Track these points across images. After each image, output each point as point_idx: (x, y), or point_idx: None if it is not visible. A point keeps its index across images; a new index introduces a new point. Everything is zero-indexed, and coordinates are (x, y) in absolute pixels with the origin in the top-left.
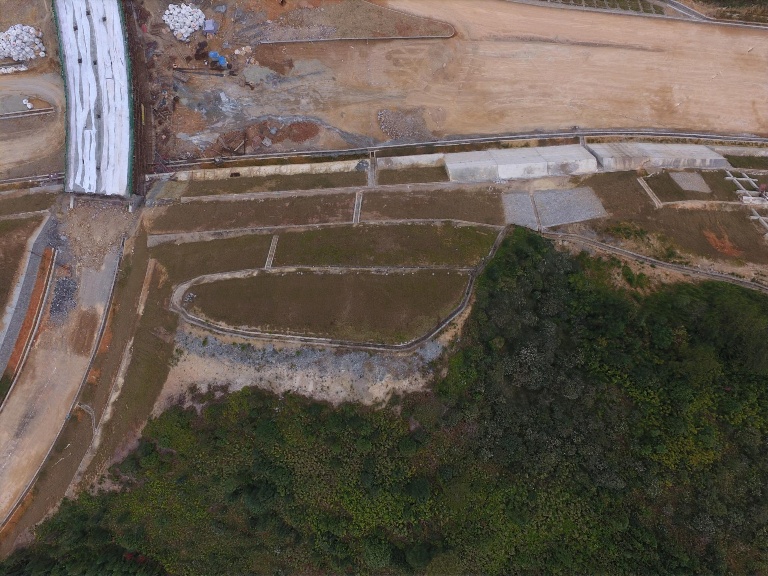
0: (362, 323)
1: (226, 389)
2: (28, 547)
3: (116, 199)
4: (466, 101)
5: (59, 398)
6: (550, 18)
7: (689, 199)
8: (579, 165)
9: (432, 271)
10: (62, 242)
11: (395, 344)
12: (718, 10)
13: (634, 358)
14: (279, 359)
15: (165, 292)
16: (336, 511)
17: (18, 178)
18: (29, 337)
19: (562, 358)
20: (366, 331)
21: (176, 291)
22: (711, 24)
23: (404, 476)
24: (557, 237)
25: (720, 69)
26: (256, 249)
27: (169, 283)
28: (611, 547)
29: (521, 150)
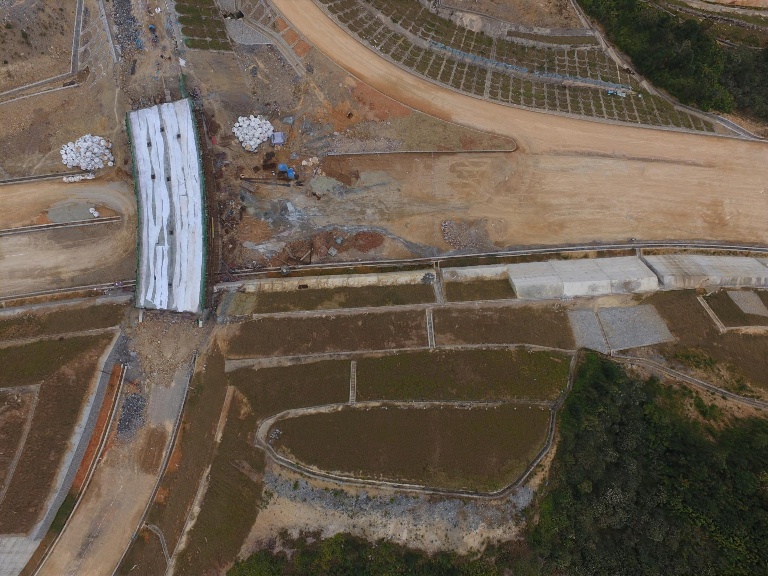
0: (454, 469)
1: (318, 536)
2: None
3: (186, 314)
4: (527, 213)
5: (125, 517)
6: (607, 134)
7: (752, 325)
8: (641, 283)
9: (514, 405)
10: (131, 358)
11: (488, 492)
12: (766, 129)
13: (718, 502)
14: (373, 506)
15: (249, 426)
16: None
17: (82, 286)
18: (95, 455)
19: (645, 497)
20: (459, 478)
21: (261, 426)
22: (759, 142)
23: None
24: (626, 360)
25: (767, 184)
26: (337, 379)
27: (253, 417)
28: None
29: (581, 262)
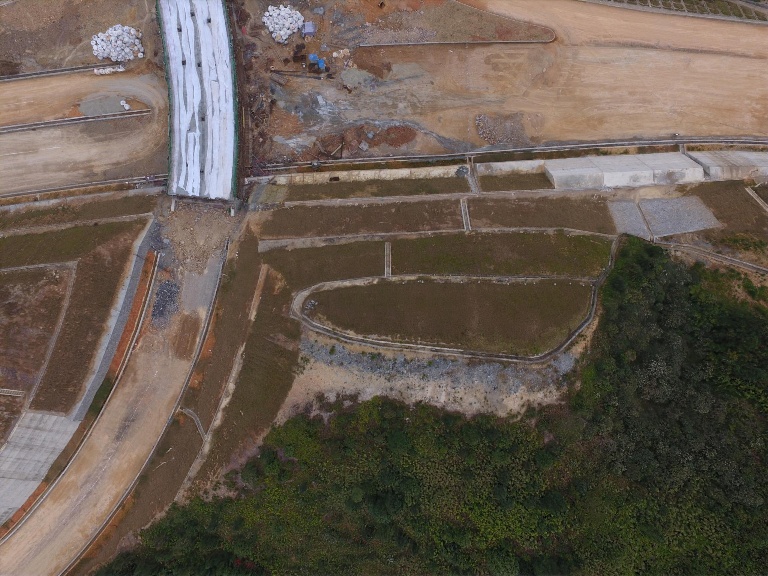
0: (494, 334)
1: (355, 398)
2: (132, 551)
3: (218, 203)
4: (565, 107)
5: (160, 402)
6: (652, 23)
7: None
8: (685, 174)
9: (554, 281)
10: (165, 245)
11: (529, 356)
12: None
13: None
14: (410, 369)
15: (283, 299)
16: (461, 522)
17: (115, 180)
18: (131, 340)
19: (690, 371)
20: (499, 342)
21: (296, 298)
22: None
23: (539, 489)
24: (669, 247)
25: None
26: (372, 256)
27: (288, 290)
28: (748, 564)
29: (621, 157)
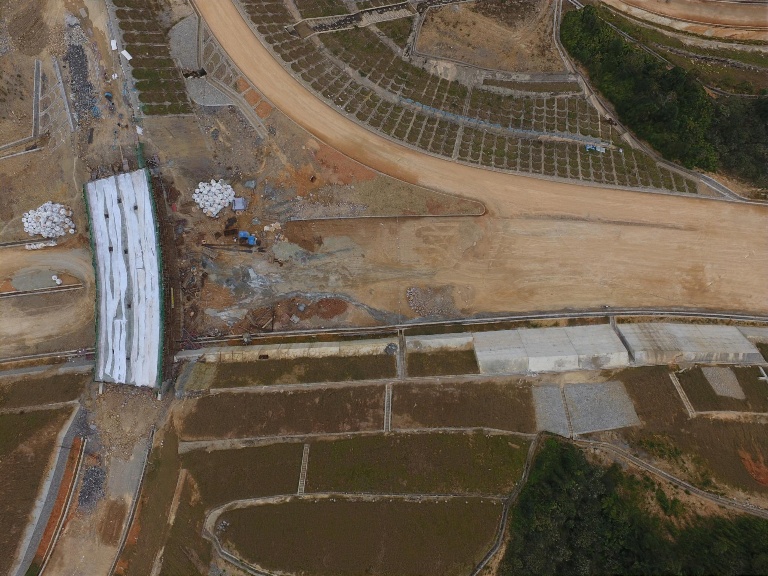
0: (397, 572)
1: None
2: None
3: (145, 387)
4: (496, 279)
5: None
6: (582, 196)
7: (723, 409)
8: (610, 358)
9: (465, 499)
10: (91, 431)
11: None
12: (752, 191)
13: None
14: None
15: (197, 514)
16: None
17: (46, 353)
18: (58, 525)
19: None
20: None
21: (209, 517)
22: (745, 204)
23: None
24: (589, 445)
25: (753, 248)
26: (288, 465)
27: (202, 507)
28: None
29: (551, 331)
